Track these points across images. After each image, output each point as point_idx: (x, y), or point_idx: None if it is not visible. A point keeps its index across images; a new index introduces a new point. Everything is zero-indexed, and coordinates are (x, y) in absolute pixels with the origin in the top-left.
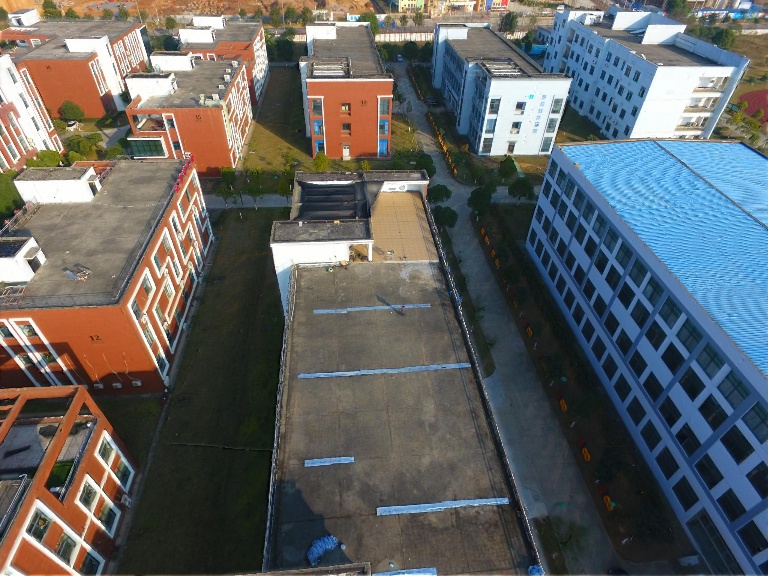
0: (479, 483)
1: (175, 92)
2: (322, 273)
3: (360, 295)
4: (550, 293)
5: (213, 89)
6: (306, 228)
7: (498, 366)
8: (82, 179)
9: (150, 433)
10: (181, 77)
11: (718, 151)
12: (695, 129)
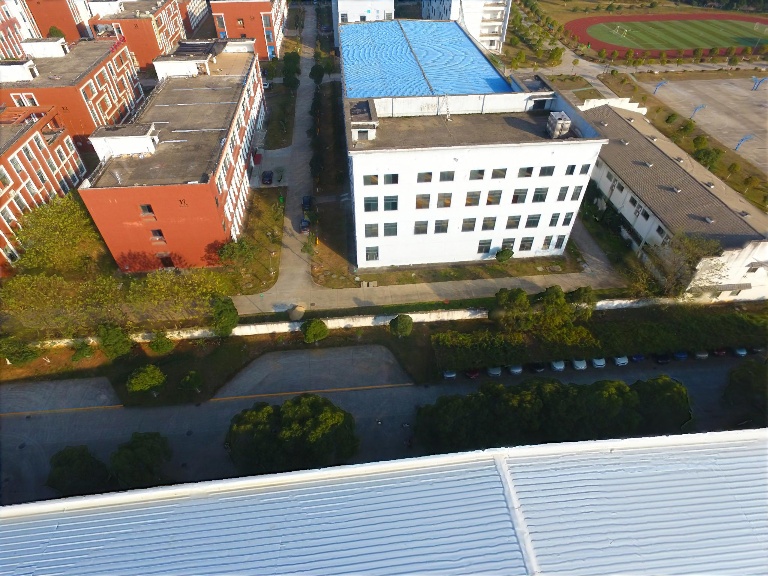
0: (218, 126)
1: (122, 12)
2: (182, 79)
3: (197, 85)
4: (343, 118)
5: (148, 10)
6: (174, 58)
7: (293, 144)
8: (57, 42)
9: (96, 164)
10: (128, 5)
11: (434, 25)
12: (495, 35)
